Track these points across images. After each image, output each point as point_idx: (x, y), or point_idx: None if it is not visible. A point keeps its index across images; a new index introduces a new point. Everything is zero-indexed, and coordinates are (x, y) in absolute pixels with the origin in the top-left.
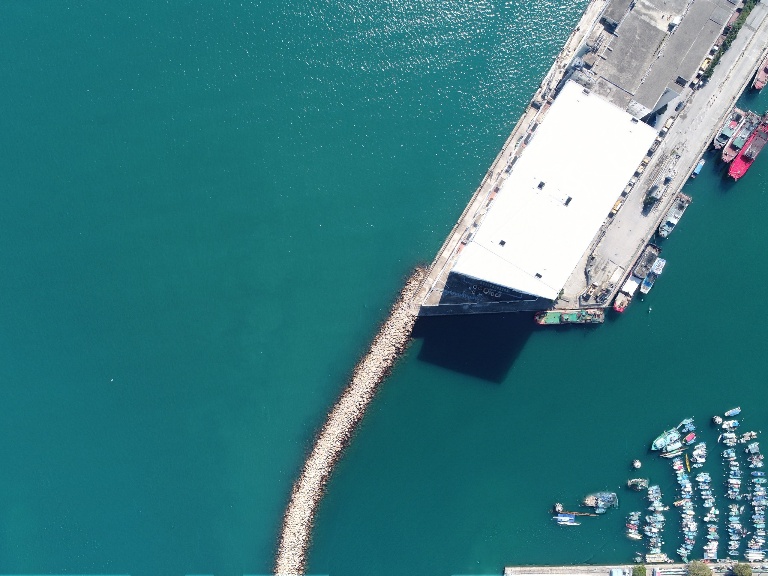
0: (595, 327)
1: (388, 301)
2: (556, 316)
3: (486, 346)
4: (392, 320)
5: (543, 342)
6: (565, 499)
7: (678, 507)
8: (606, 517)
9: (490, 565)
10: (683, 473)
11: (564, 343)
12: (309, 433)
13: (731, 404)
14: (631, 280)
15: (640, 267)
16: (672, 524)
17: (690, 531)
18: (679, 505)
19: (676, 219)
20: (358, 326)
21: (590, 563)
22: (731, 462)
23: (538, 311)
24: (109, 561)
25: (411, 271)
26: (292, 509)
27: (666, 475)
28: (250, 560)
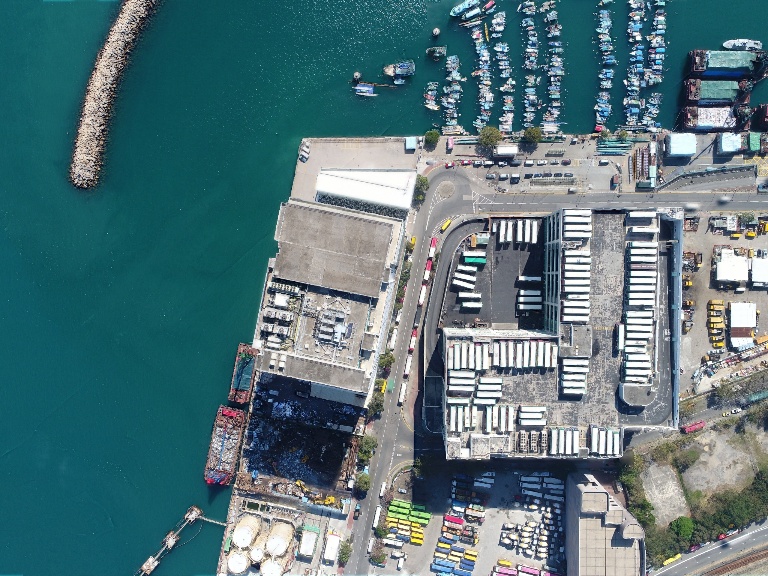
0: None
1: None
2: None
3: None
4: None
5: None
6: (365, 69)
7: (476, 79)
8: (405, 88)
9: (288, 137)
10: (482, 43)
11: None
12: (116, 2)
13: None
14: None
15: None
16: (469, 96)
17: (486, 101)
18: (476, 74)
19: None
20: None
21: (387, 134)
22: (529, 32)
23: None
24: None
25: None
26: (94, 75)
27: (465, 45)
28: (53, 132)
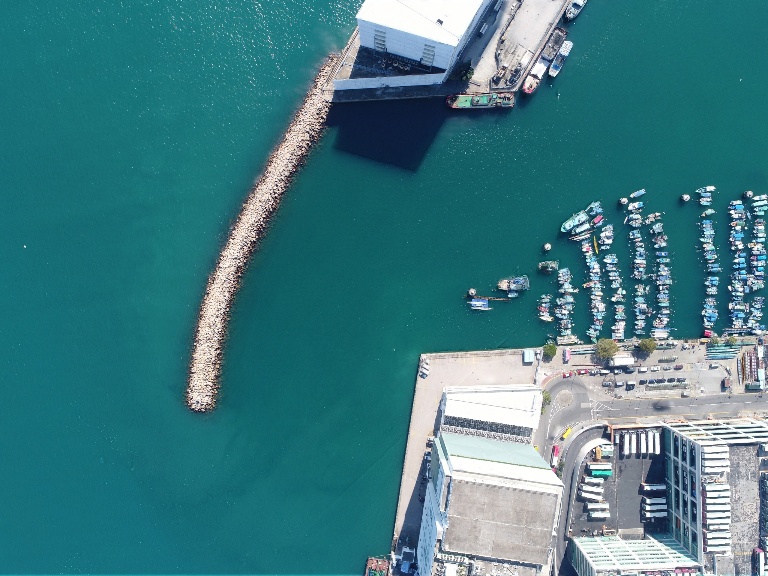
0: (506, 113)
1: (302, 90)
2: (467, 100)
3: (400, 133)
4: (306, 107)
5: (455, 127)
6: (479, 284)
7: (587, 289)
8: (518, 301)
9: (406, 353)
10: (591, 255)
11: None
12: (224, 225)
13: (636, 187)
14: (539, 63)
15: (547, 48)
16: (582, 306)
17: (598, 311)
18: (588, 286)
19: (581, 0)
20: (272, 114)
21: (503, 347)
22: (637, 243)
23: (450, 95)
24: (14, 345)
25: (325, 58)
26: (207, 301)
27: (575, 257)
28: (165, 357)
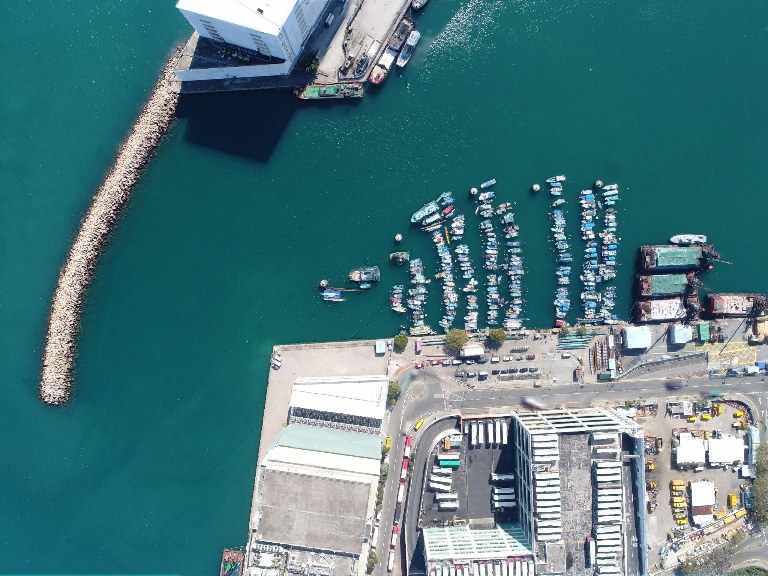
0: (356, 103)
1: (152, 81)
2: (315, 90)
3: (249, 124)
4: (154, 98)
5: (305, 118)
6: (331, 275)
7: (440, 280)
8: (371, 292)
9: (259, 344)
10: (443, 246)
11: (326, 119)
12: (75, 218)
13: (488, 177)
14: (387, 53)
15: (393, 38)
16: (434, 297)
17: (450, 302)
18: (440, 277)
19: None
20: (121, 106)
21: (356, 338)
22: (488, 233)
23: (297, 85)
24: None
25: (173, 49)
26: (58, 294)
27: (427, 248)
28: (19, 350)
